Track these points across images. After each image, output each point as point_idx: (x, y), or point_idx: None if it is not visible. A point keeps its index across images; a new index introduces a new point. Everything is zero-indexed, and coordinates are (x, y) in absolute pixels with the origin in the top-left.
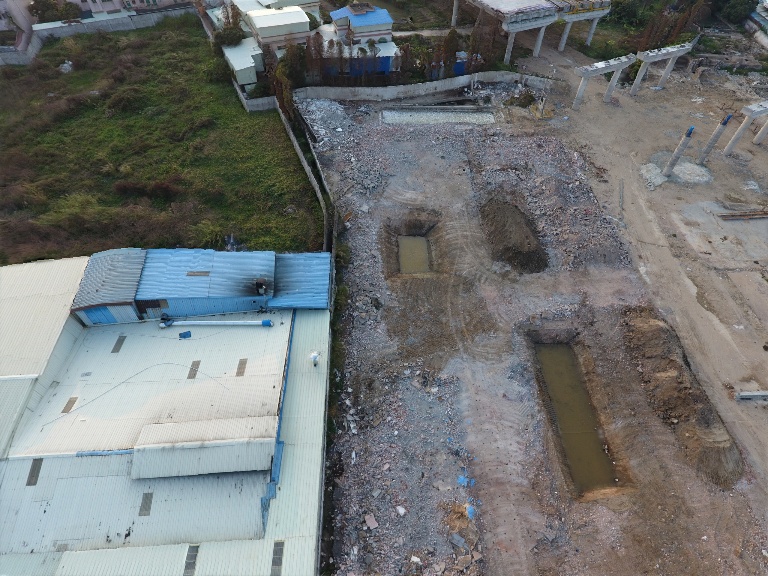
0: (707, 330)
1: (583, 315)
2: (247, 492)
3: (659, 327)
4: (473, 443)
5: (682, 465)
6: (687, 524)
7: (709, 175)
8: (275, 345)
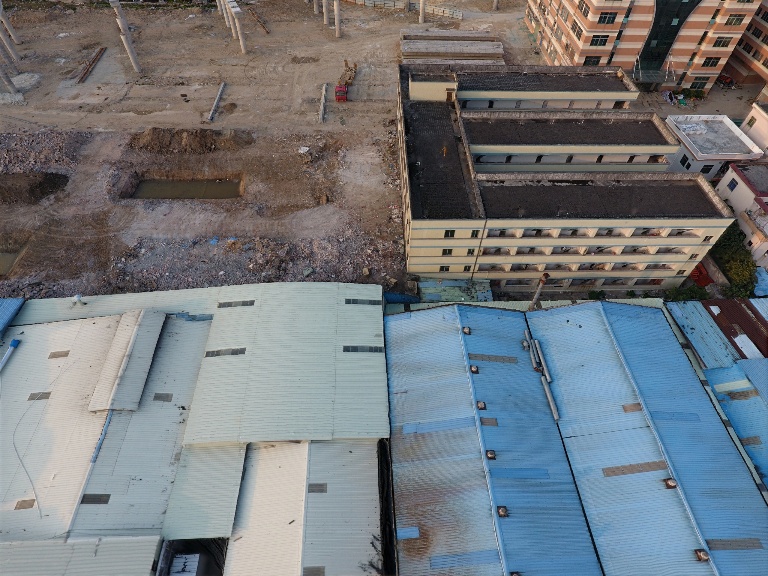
0: (164, 118)
1: (122, 166)
2: (178, 329)
3: (152, 129)
4: (191, 235)
5: (238, 152)
6: (266, 159)
7: (34, 74)
8: (47, 333)
